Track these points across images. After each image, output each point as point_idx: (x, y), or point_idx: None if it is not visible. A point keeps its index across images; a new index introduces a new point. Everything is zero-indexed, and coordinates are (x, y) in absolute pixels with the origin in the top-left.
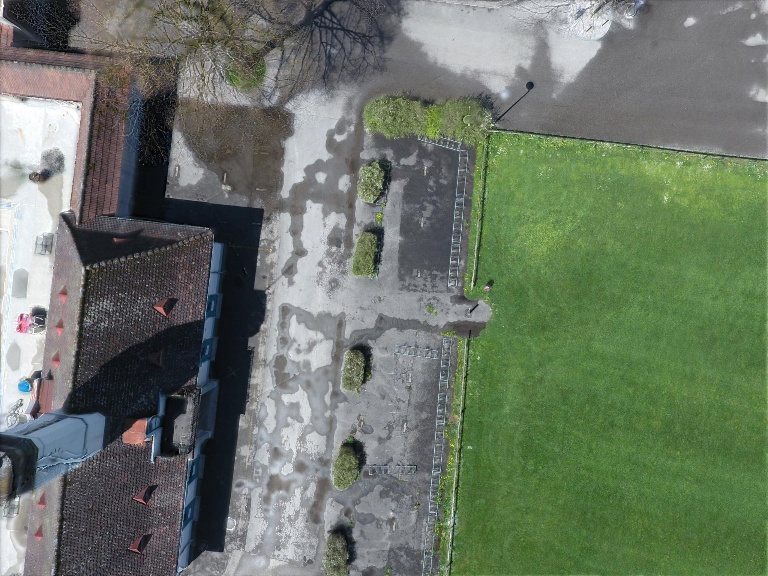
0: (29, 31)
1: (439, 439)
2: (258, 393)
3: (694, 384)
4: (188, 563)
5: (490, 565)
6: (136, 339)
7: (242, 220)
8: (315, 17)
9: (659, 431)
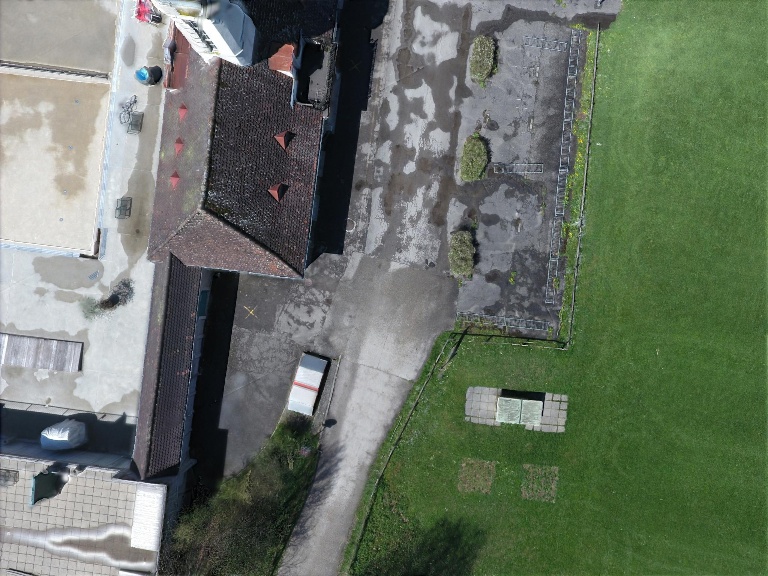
0: None
1: (566, 136)
2: (380, 88)
3: None
4: (306, 266)
5: (618, 269)
6: None
7: None
8: None
9: None
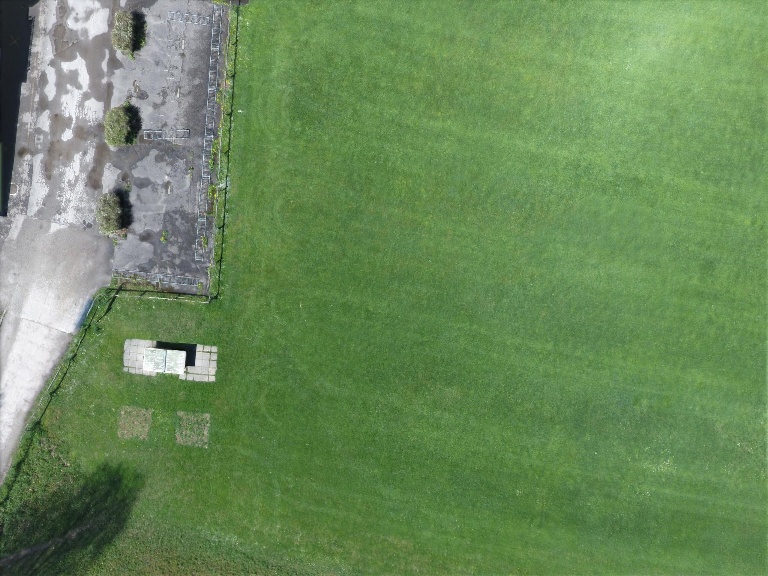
0: None
1: (211, 104)
2: (39, 61)
3: (453, 45)
4: None
5: (262, 227)
6: None
7: None
8: None
9: (421, 93)
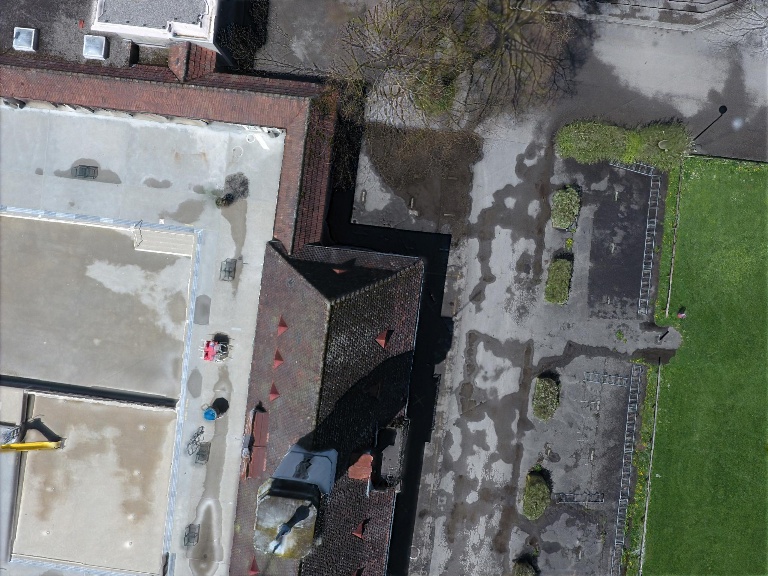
0: (227, 56)
1: (627, 467)
2: (444, 421)
3: None
4: None
5: None
6: (362, 373)
7: (429, 246)
8: (505, 40)
9: None
